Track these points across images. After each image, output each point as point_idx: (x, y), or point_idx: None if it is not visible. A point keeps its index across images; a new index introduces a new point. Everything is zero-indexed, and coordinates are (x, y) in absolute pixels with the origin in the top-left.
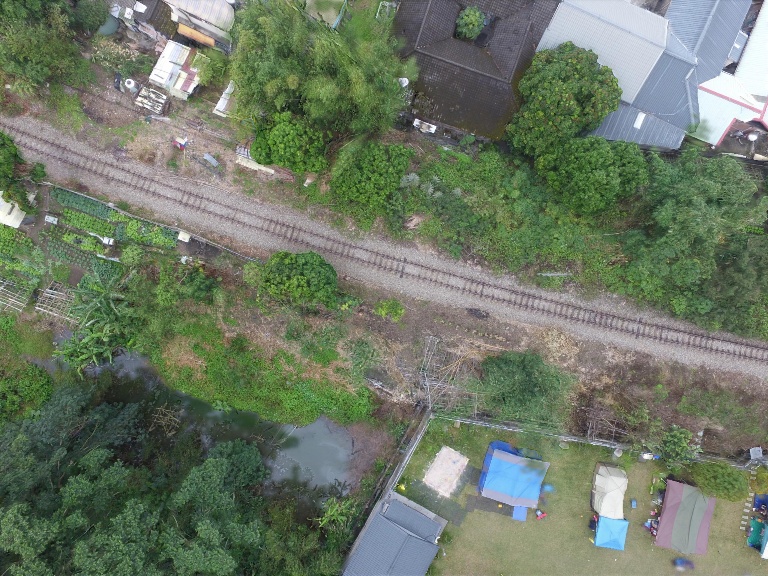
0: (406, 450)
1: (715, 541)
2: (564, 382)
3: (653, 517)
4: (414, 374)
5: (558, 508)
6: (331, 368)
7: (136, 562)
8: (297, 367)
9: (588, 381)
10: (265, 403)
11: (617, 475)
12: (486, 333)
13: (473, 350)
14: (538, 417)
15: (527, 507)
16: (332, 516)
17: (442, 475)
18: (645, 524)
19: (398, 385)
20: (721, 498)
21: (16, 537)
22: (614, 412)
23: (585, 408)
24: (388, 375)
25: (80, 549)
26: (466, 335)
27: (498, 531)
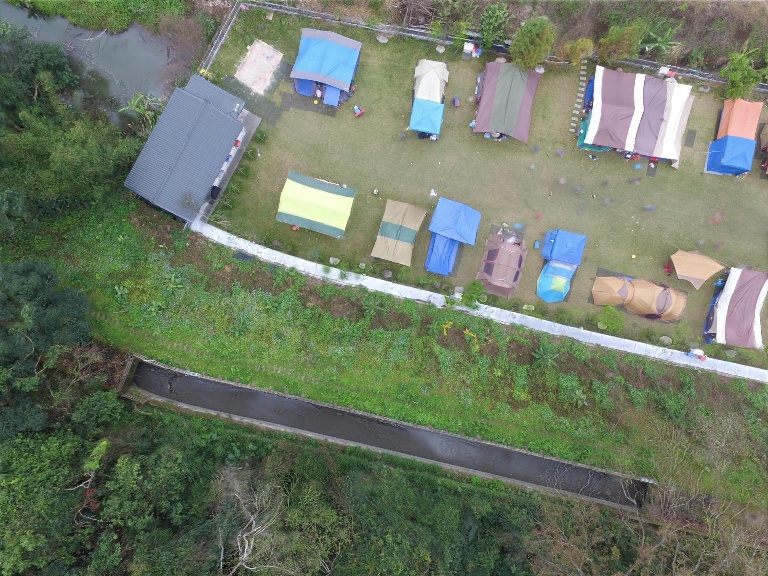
0: None
1: (543, 144)
2: None
3: None
4: None
5: (378, 108)
6: None
7: None
8: None
9: None
10: (71, 2)
11: None
12: None
13: None
14: None
15: (337, 88)
16: (137, 107)
17: (256, 73)
18: (470, 125)
19: None
20: (533, 62)
21: None
22: None
23: None
24: None
25: None
26: None
27: (315, 131)
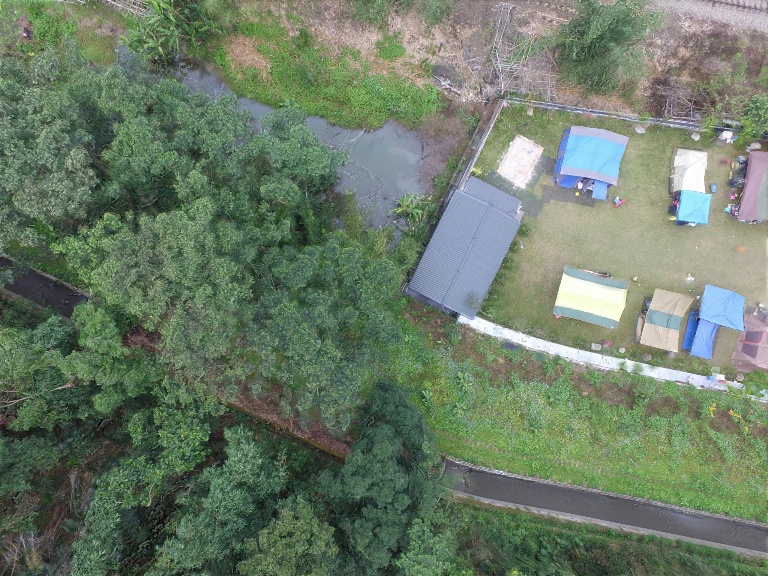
0: (478, 146)
1: None
2: (638, 64)
3: (733, 202)
4: (483, 66)
5: (636, 196)
6: (399, 62)
7: (237, 130)
8: (364, 63)
9: (663, 60)
10: (332, 104)
11: (697, 151)
12: (558, 5)
13: (545, 26)
14: (611, 109)
15: (607, 183)
16: (408, 207)
17: (516, 167)
18: (725, 209)
19: (467, 81)
20: None
21: (117, 93)
22: (691, 89)
23: (661, 87)
24: (456, 71)
25: (181, 109)
26: (538, 8)
27: (575, 222)
